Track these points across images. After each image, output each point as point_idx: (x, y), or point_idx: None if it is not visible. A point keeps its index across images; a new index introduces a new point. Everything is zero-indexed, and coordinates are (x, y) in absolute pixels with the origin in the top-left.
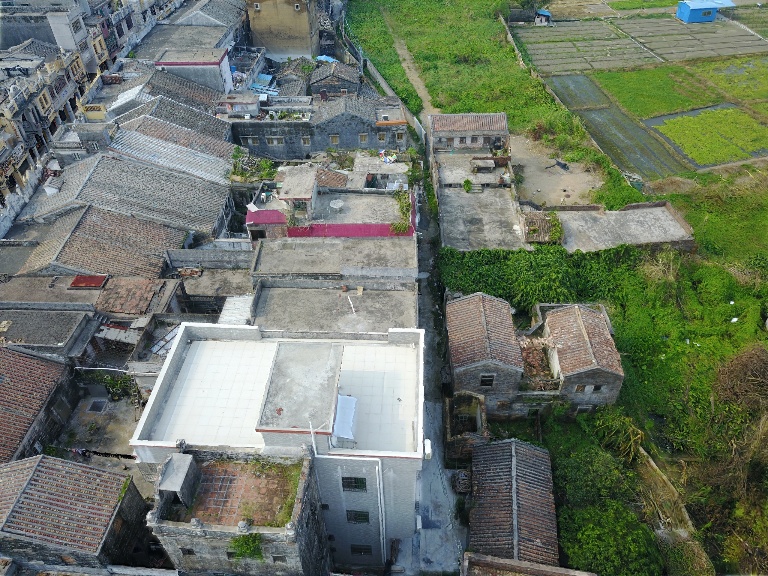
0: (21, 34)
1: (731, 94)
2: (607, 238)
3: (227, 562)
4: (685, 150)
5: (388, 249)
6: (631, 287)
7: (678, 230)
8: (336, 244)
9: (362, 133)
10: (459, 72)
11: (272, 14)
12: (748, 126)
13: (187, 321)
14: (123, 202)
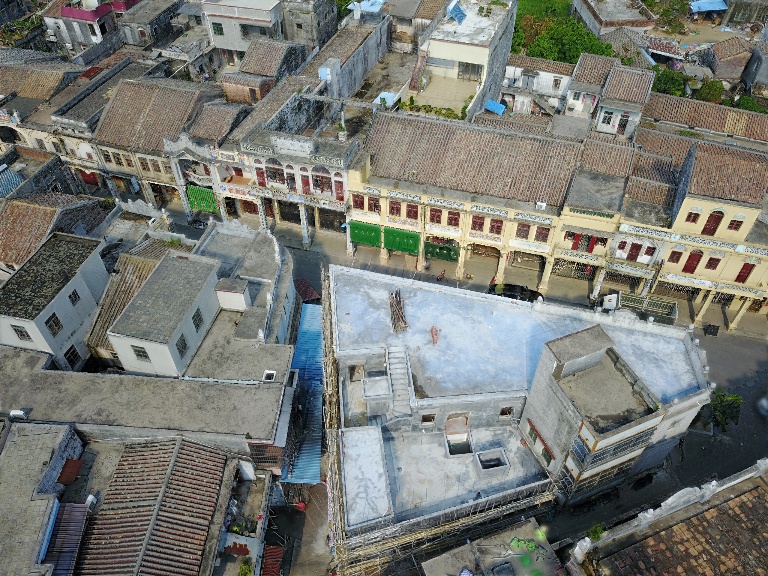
0: None
1: None
2: None
3: (325, 25)
4: None
5: None
6: None
7: None
8: (148, 2)
9: (1, 9)
10: None
11: None
12: None
13: (165, 46)
14: (5, 61)
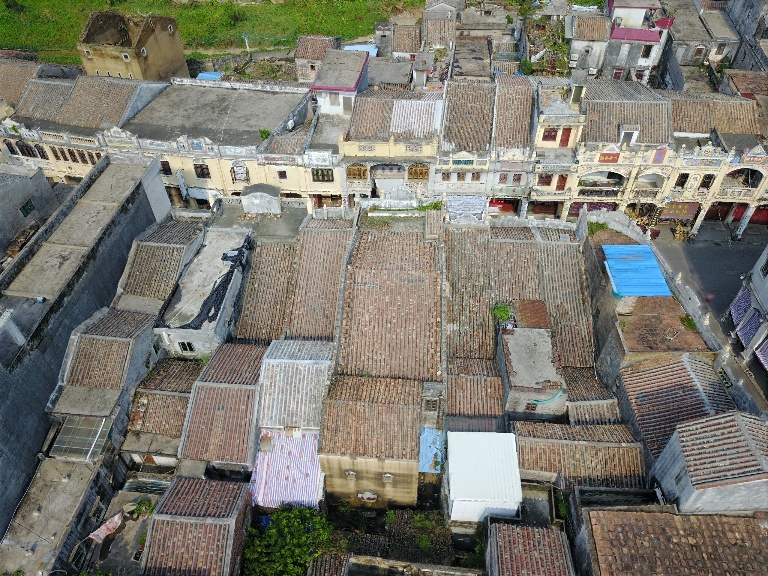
0: (123, 245)
1: None
2: None
3: None
4: None
5: (668, 3)
6: (590, 4)
7: None
8: None
9: None
10: (254, 27)
11: (156, 53)
12: None
13: None
14: None
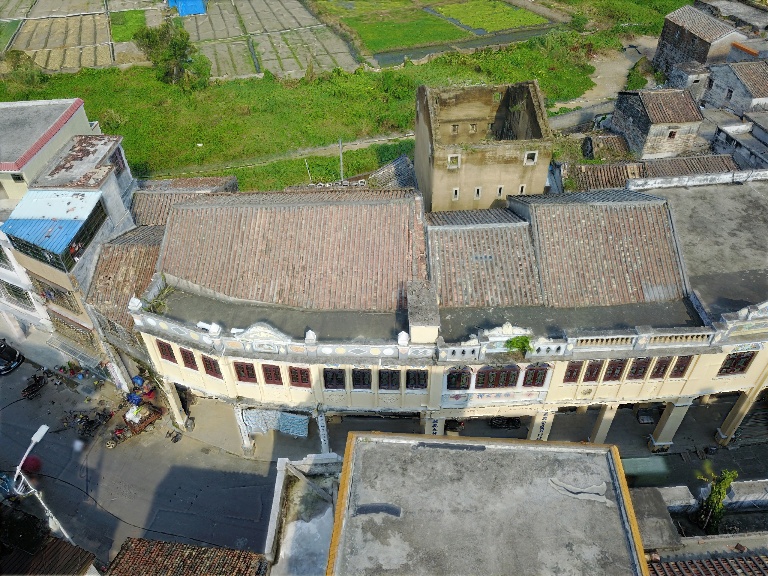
0: None
1: (406, 6)
2: (764, 17)
3: None
4: (529, 24)
5: None
6: None
7: (722, 2)
8: None
9: None
10: None
11: None
12: (467, 7)
13: None
14: None
